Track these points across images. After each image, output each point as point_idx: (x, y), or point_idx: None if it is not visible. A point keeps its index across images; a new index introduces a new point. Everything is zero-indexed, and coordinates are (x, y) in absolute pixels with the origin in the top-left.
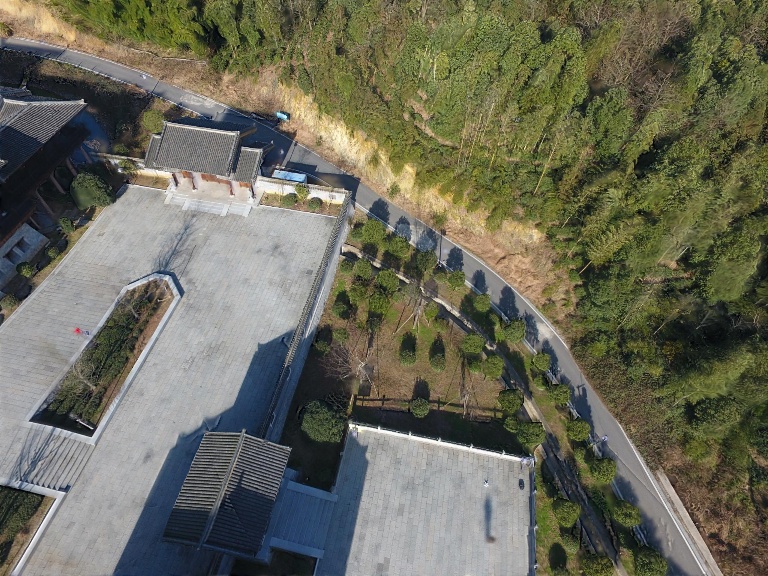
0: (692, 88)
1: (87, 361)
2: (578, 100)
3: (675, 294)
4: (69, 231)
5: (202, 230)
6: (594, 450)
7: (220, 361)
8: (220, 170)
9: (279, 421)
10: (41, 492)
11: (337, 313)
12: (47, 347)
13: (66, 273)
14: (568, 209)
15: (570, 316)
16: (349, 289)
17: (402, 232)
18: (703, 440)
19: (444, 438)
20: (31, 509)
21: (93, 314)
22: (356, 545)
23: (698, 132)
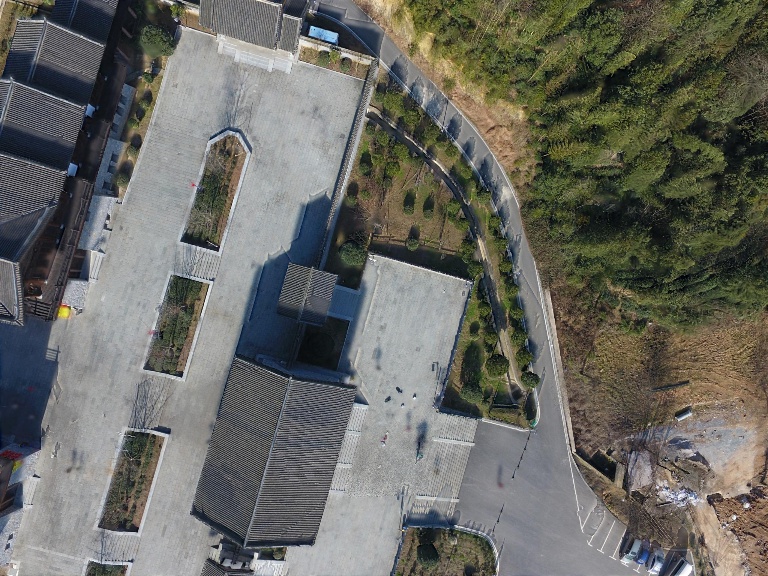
0: (679, 18)
1: (201, 202)
2: (584, 7)
3: (604, 180)
4: (150, 82)
5: (255, 87)
6: (513, 275)
7: (286, 206)
8: (268, 43)
9: (326, 249)
10: (201, 281)
11: (362, 173)
12: (171, 190)
13: (161, 124)
14: (547, 108)
15: (527, 185)
16: (371, 151)
17: (416, 95)
18: (580, 275)
19: (425, 263)
20: (199, 289)
21: (193, 164)
22: (370, 316)
23: (678, 45)
